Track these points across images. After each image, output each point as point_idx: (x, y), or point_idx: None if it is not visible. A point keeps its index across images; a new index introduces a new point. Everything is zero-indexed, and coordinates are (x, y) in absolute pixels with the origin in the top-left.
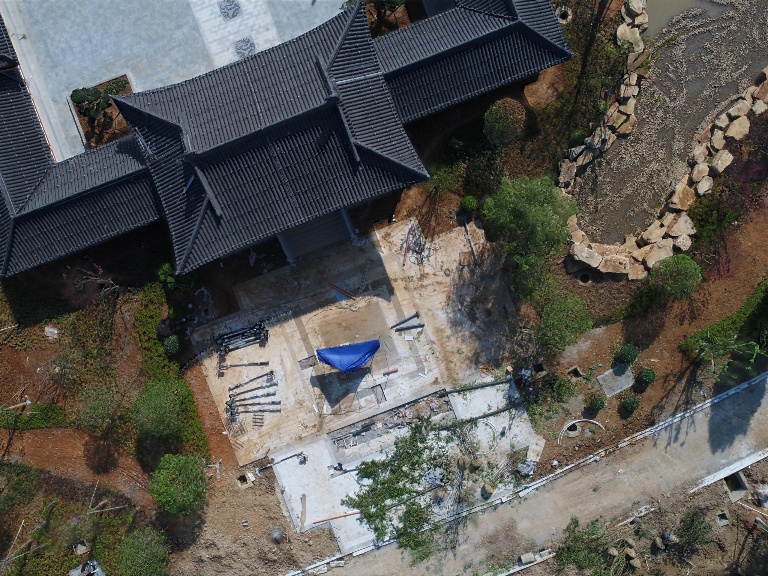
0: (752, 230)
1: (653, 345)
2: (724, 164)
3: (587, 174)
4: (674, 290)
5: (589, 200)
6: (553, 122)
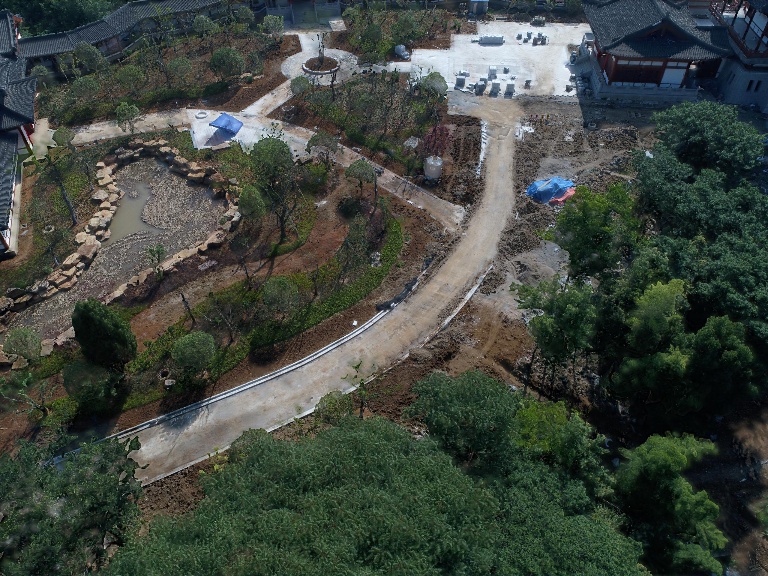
0: None
1: (8, 417)
2: (115, 296)
3: (26, 311)
4: (5, 349)
5: (19, 326)
6: (8, 278)
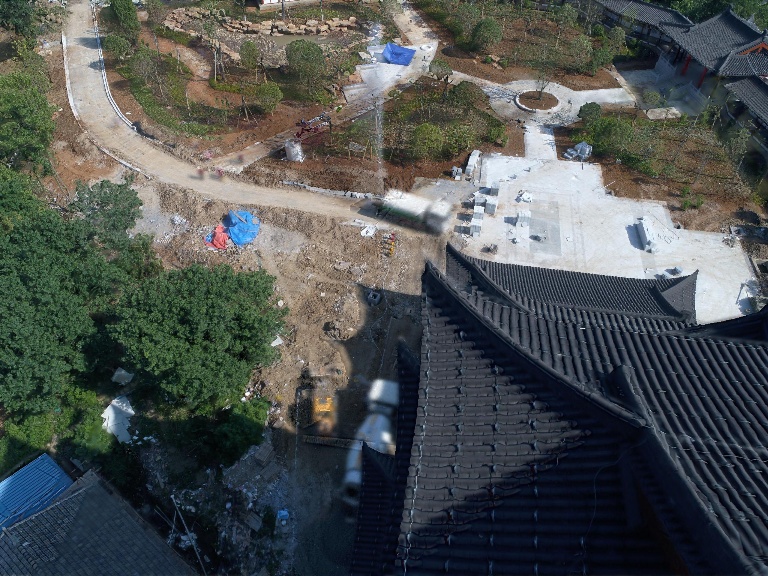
0: (167, 44)
1: None
2: None
3: None
4: None
5: None
6: None
